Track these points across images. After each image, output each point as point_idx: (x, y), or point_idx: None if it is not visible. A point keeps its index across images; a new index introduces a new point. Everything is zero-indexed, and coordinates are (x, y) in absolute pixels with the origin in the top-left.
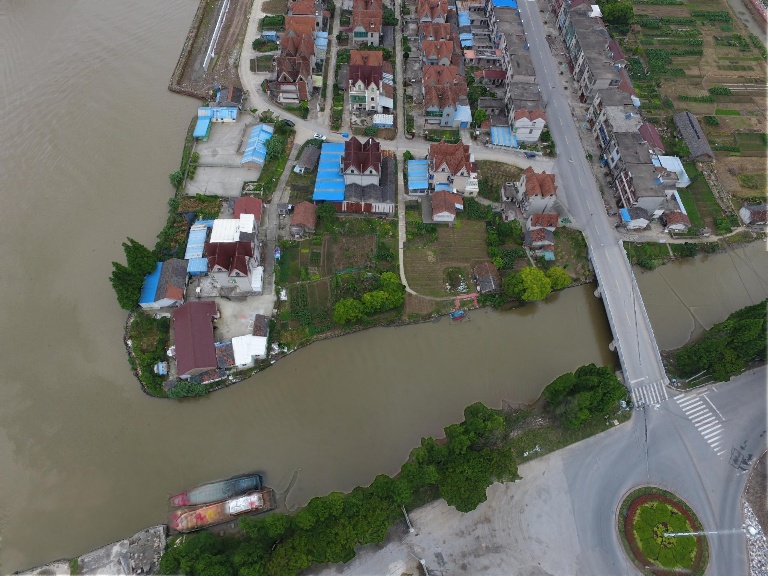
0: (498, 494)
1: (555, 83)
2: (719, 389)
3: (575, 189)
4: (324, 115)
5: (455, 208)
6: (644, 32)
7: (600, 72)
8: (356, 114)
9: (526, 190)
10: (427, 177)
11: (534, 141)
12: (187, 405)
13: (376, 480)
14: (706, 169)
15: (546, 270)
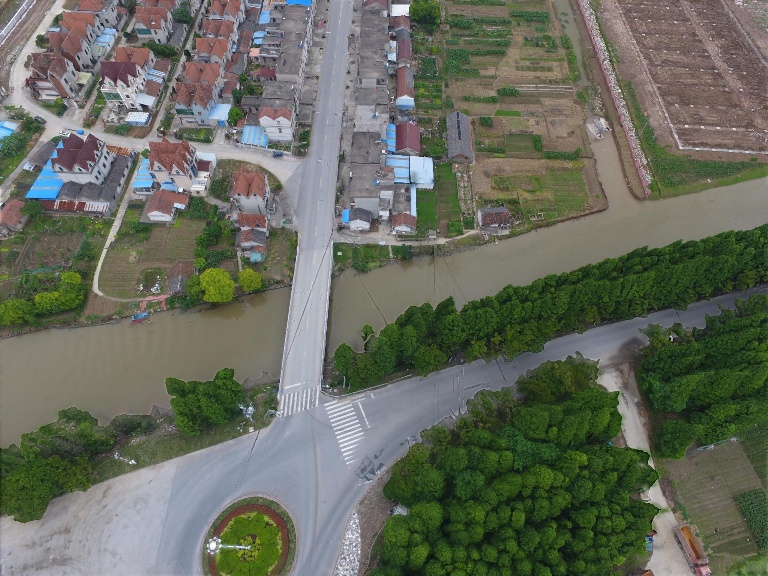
0: (91, 503)
1: (338, 82)
2: (377, 395)
3: (311, 189)
4: (82, 112)
5: (174, 208)
6: (453, 32)
7: (367, 71)
8: (115, 112)
9: None
10: None
11: (289, 140)
12: None
13: None
14: (462, 170)
15: None
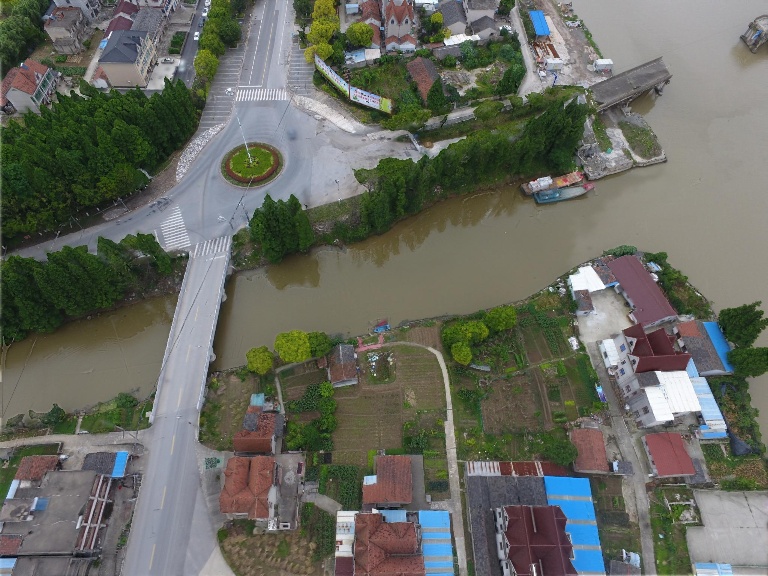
0: None
1: None
2: None
3: (170, 535)
4: None
5: (377, 475)
6: None
7: None
8: None
9: None
10: None
11: None
12: None
13: (461, 155)
14: None
15: (266, 384)
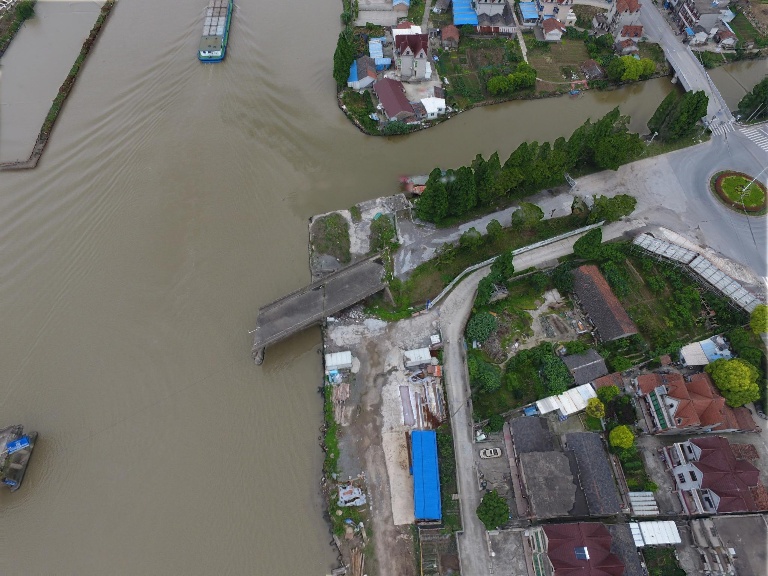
0: (627, 173)
1: None
2: None
3: (648, 20)
4: None
5: None
6: None
7: None
8: None
9: (617, 10)
10: (537, 11)
11: None
12: (393, 143)
13: None
14: (745, 11)
15: None
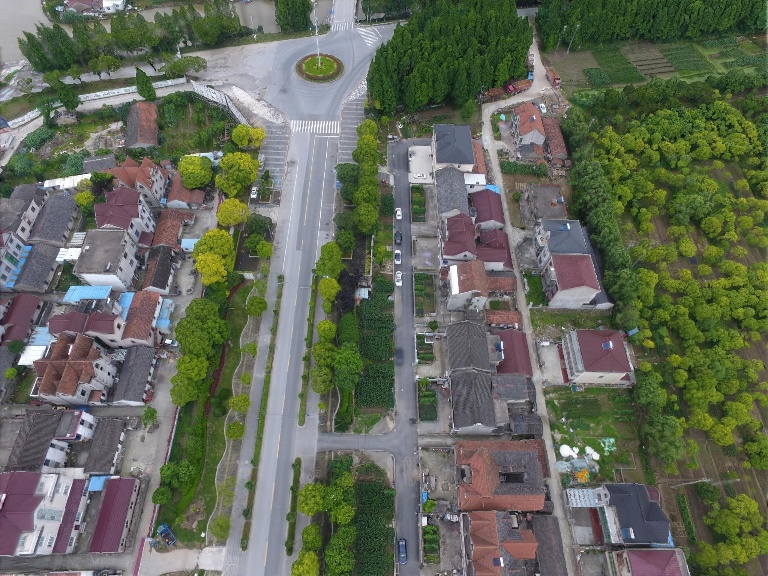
0: (235, 51)
1: None
2: (386, 27)
3: None
4: None
5: None
6: None
7: None
8: None
9: None
10: None
11: None
12: None
13: None
14: None
15: None
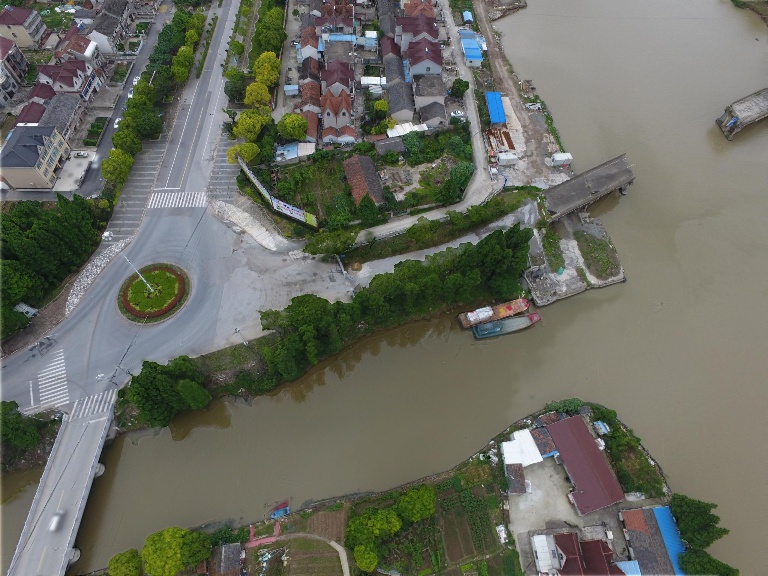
0: None
1: None
2: None
3: None
4: None
5: None
6: None
7: None
8: None
9: None
10: None
11: None
12: None
13: (381, 299)
14: None
15: None
